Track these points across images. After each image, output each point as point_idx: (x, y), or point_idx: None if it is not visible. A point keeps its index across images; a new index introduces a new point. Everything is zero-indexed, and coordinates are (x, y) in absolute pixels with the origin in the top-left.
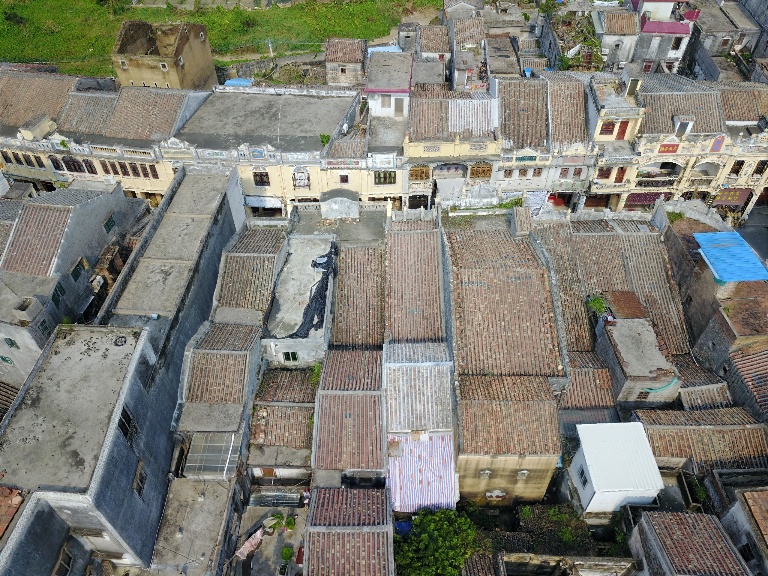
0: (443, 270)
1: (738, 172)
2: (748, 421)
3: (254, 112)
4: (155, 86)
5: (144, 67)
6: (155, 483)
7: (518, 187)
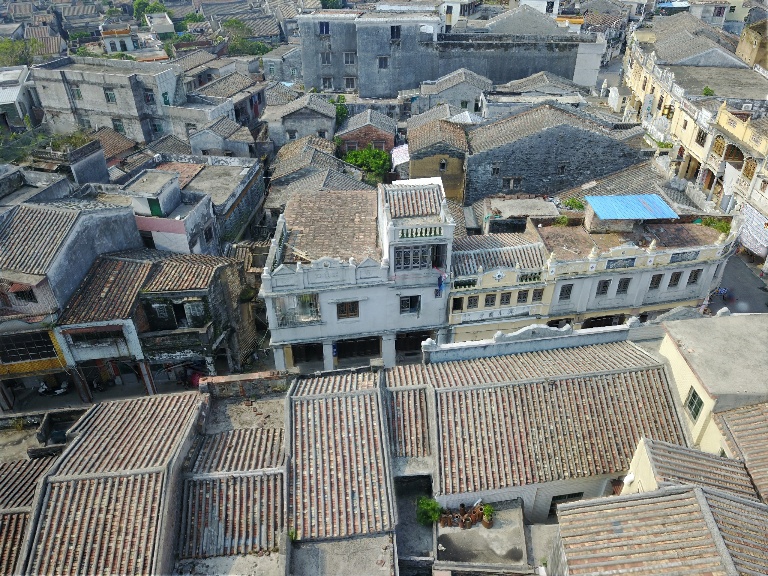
0: None
1: None
2: None
3: (736, 81)
4: (745, 59)
5: (749, 41)
6: (391, 81)
7: (765, 209)
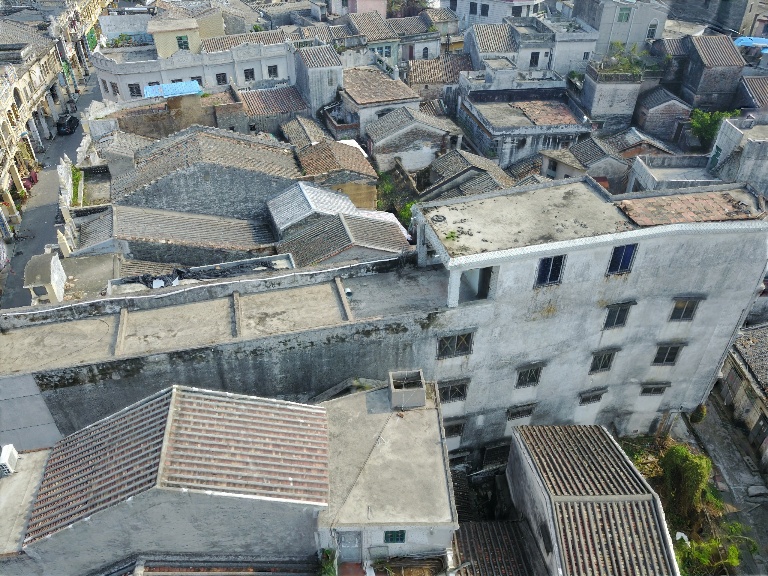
0: (174, 207)
1: (13, 123)
2: (294, 121)
3: None
4: None
5: None
6: None
7: None
